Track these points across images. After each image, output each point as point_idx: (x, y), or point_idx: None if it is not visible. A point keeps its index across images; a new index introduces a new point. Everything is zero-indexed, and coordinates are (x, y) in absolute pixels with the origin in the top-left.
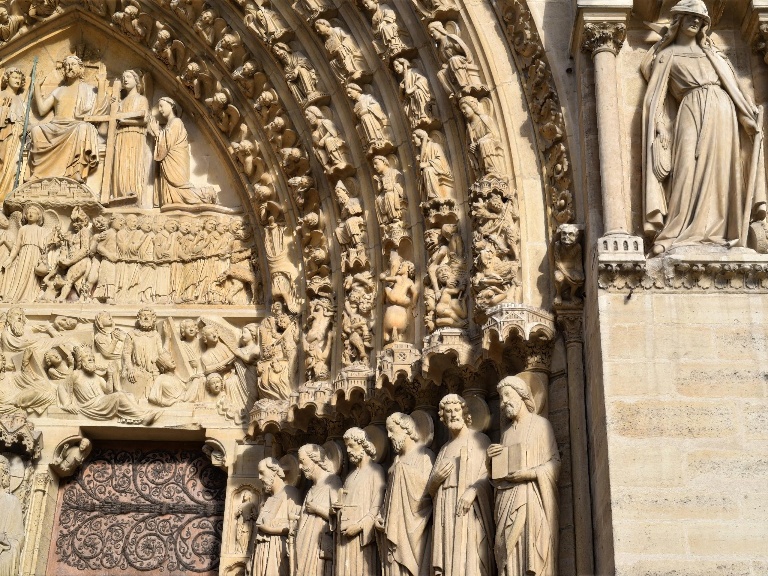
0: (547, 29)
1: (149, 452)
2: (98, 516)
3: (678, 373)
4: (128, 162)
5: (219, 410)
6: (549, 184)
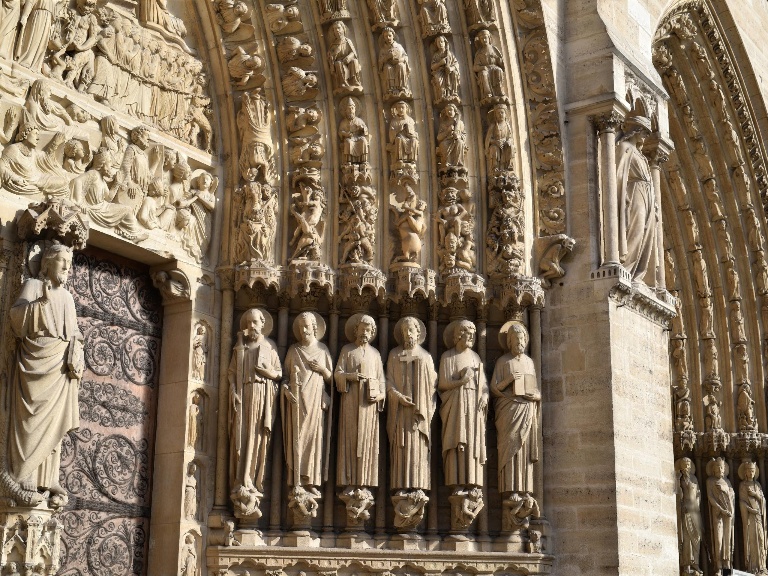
0: None
1: (102, 261)
2: None
3: None
4: None
5: (184, 245)
6: (539, 194)
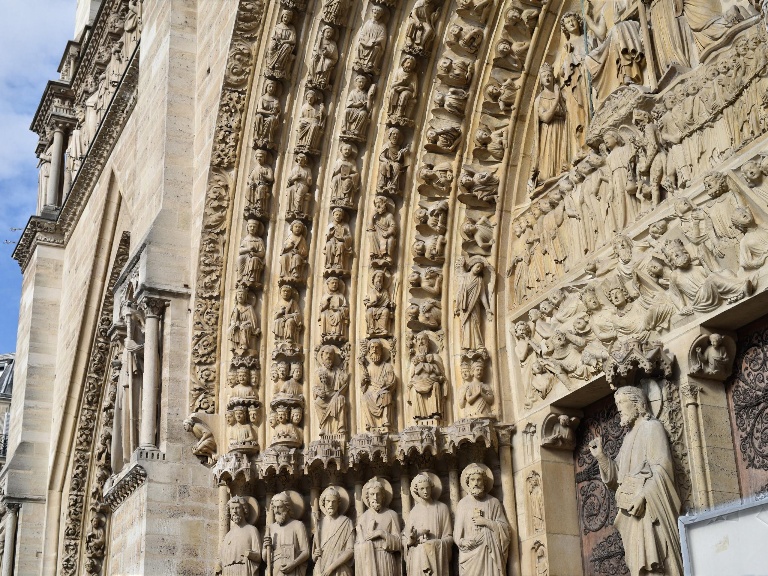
0: None
1: None
2: (764, 408)
3: None
4: (662, 35)
5: None
6: None
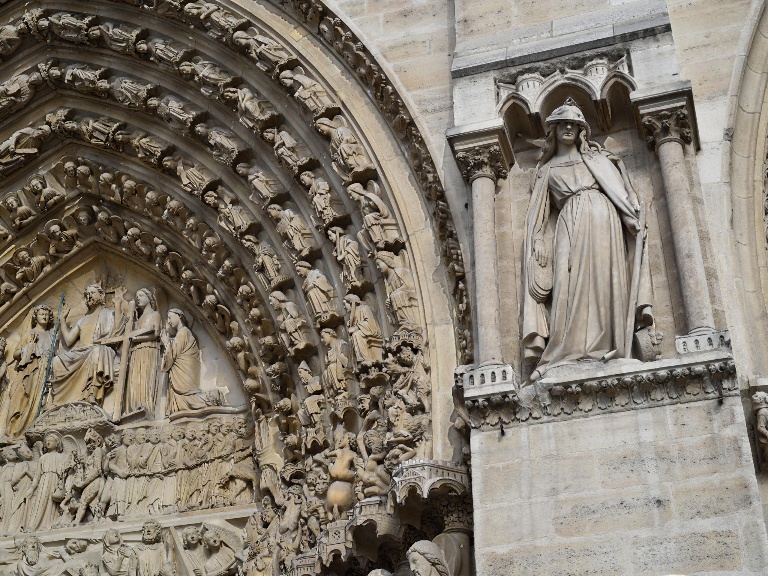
0: (447, 168)
1: None
2: None
3: (557, 511)
4: (139, 377)
5: None
6: None
